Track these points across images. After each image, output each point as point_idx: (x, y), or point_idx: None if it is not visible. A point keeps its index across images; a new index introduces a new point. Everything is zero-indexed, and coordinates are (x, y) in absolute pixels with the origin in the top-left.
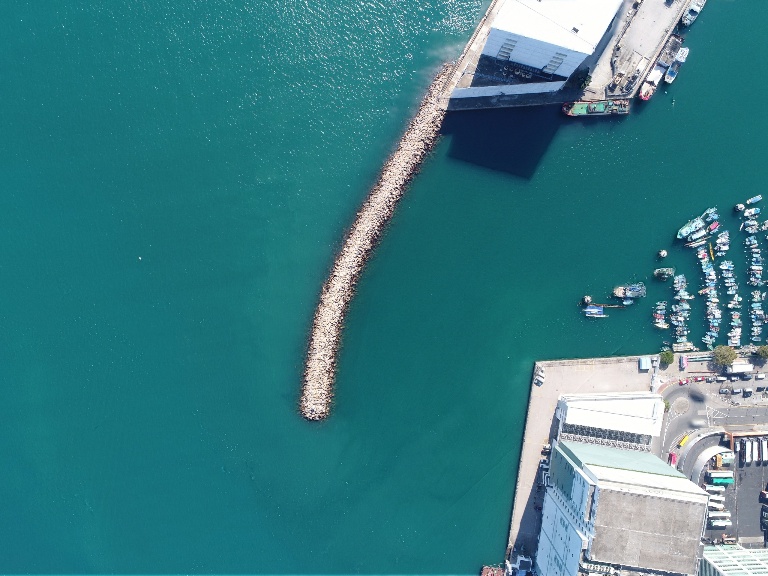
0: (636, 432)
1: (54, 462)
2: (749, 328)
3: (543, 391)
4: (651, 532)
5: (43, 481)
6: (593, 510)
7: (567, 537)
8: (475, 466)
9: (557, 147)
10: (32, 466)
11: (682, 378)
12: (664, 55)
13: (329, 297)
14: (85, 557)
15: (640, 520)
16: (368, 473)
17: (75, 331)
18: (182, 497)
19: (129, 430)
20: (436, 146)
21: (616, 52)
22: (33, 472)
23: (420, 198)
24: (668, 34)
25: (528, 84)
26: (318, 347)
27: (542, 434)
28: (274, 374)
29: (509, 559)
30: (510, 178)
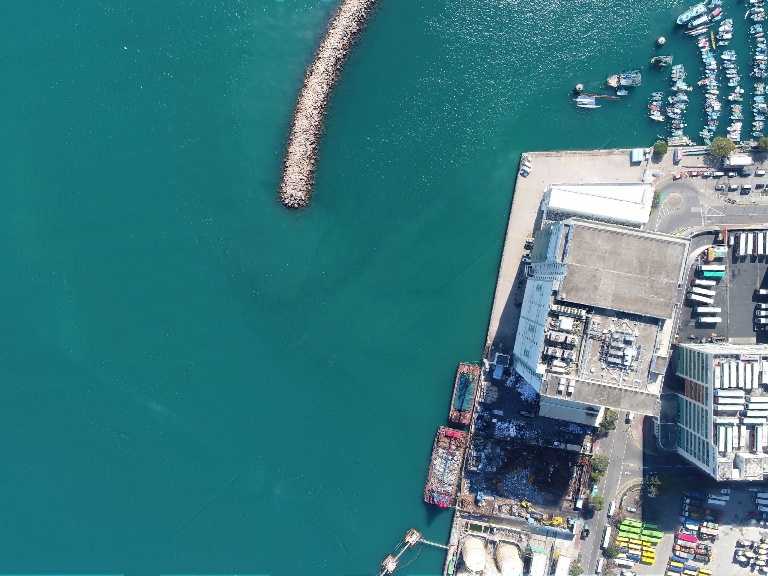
0: (623, 217)
1: (34, 237)
2: (750, 123)
3: (529, 182)
4: (626, 272)
5: (23, 259)
6: (566, 250)
7: (541, 295)
8: (455, 261)
9: None
10: (13, 244)
11: (676, 173)
12: None
13: (312, 80)
14: (63, 343)
15: (615, 259)
16: (346, 264)
17: (56, 94)
18: (155, 265)
19: (105, 195)
20: None
21: None
22: (14, 250)
23: None
24: None
25: None
26: (299, 130)
27: (526, 227)
28: (254, 158)
29: (487, 358)
30: None
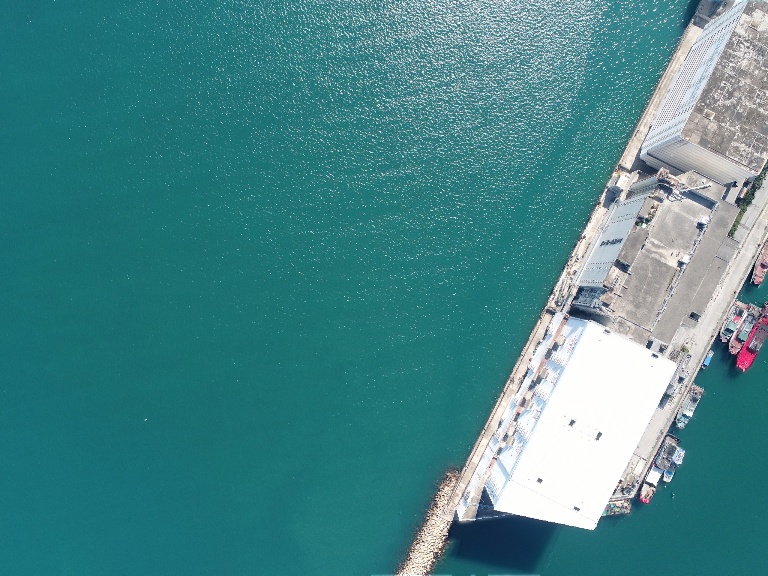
0: None
1: None
2: None
3: None
4: None
5: None
6: None
7: None
8: None
9: (563, 546)
10: None
11: None
12: (661, 460)
13: None
14: None
15: None
16: None
17: None
18: None
19: None
20: (445, 552)
21: None
22: None
23: None
24: (663, 435)
25: None
26: None
27: None
28: None
29: None
30: None
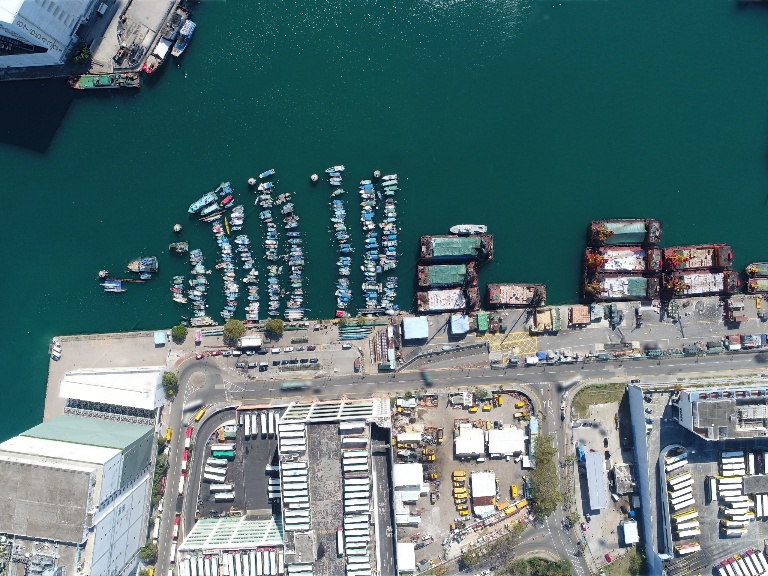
0: (130, 405)
1: None
2: (267, 302)
3: (61, 366)
4: (38, 501)
5: None
6: None
7: None
8: None
9: (70, 121)
10: None
11: (198, 352)
12: (164, 27)
13: None
14: None
15: (26, 489)
16: None
17: None
18: None
19: None
20: None
21: (122, 24)
22: None
23: None
24: (174, 6)
25: (10, 56)
26: None
27: (61, 409)
28: None
29: None
30: (20, 152)
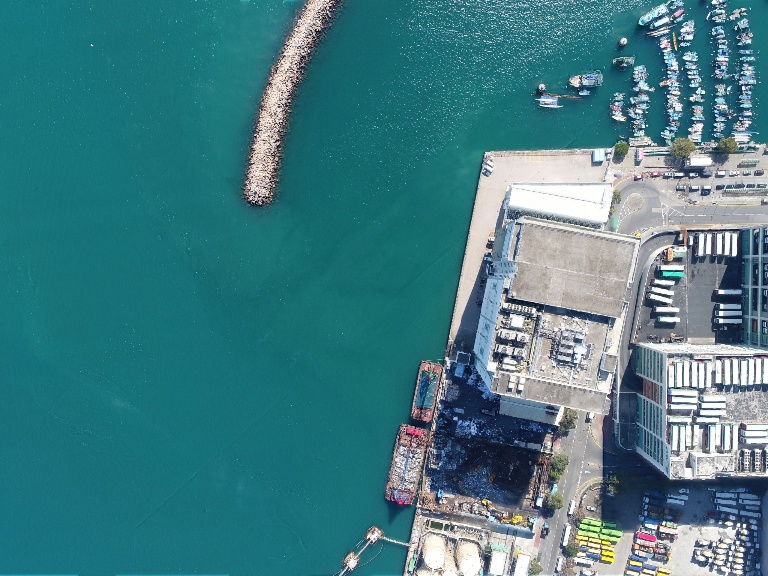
0: (582, 216)
1: None
2: (711, 124)
3: (491, 182)
4: (576, 271)
5: None
6: (517, 248)
7: (495, 293)
8: (418, 259)
9: None
10: None
11: (637, 173)
12: None
13: (277, 77)
14: (28, 338)
15: (565, 258)
16: (309, 262)
17: (20, 90)
18: (117, 261)
19: (68, 191)
20: None
21: None
22: None
23: None
24: None
25: None
26: (263, 128)
27: (488, 226)
28: (219, 156)
29: (449, 356)
30: None
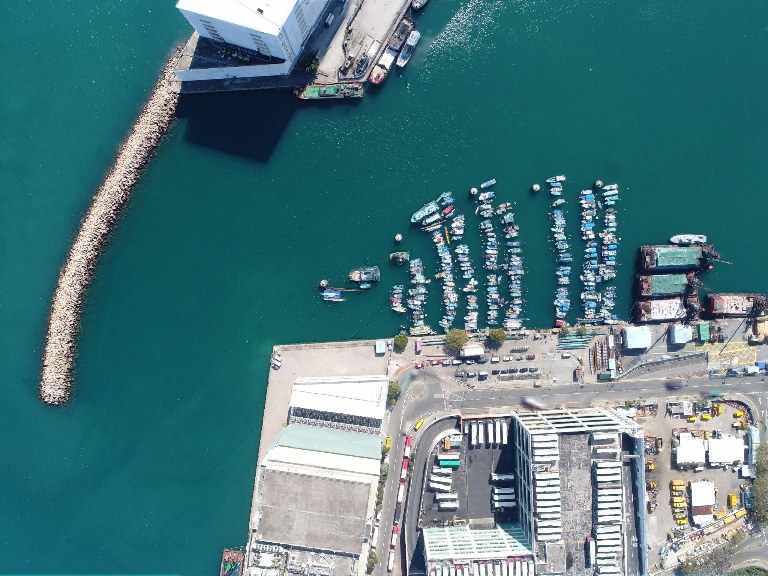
0: (360, 415)
1: None
2: (485, 312)
3: (280, 375)
4: (317, 512)
5: None
6: None
7: None
8: (216, 450)
9: (293, 131)
10: None
11: (418, 362)
12: (392, 38)
13: (64, 281)
14: None
15: (306, 500)
16: (109, 457)
17: None
18: None
19: None
20: (172, 129)
21: (348, 35)
22: None
23: (159, 182)
24: (400, 17)
25: (247, 66)
26: (54, 331)
27: (280, 418)
28: (12, 359)
29: None
30: (244, 162)
